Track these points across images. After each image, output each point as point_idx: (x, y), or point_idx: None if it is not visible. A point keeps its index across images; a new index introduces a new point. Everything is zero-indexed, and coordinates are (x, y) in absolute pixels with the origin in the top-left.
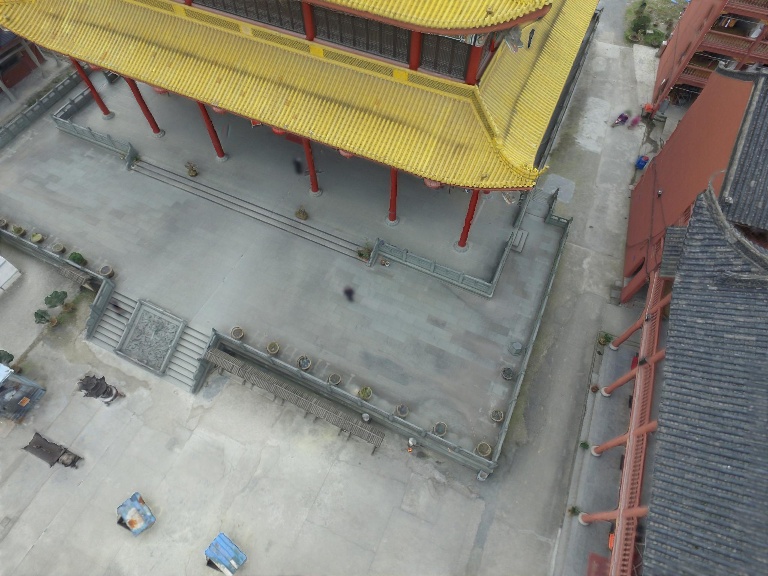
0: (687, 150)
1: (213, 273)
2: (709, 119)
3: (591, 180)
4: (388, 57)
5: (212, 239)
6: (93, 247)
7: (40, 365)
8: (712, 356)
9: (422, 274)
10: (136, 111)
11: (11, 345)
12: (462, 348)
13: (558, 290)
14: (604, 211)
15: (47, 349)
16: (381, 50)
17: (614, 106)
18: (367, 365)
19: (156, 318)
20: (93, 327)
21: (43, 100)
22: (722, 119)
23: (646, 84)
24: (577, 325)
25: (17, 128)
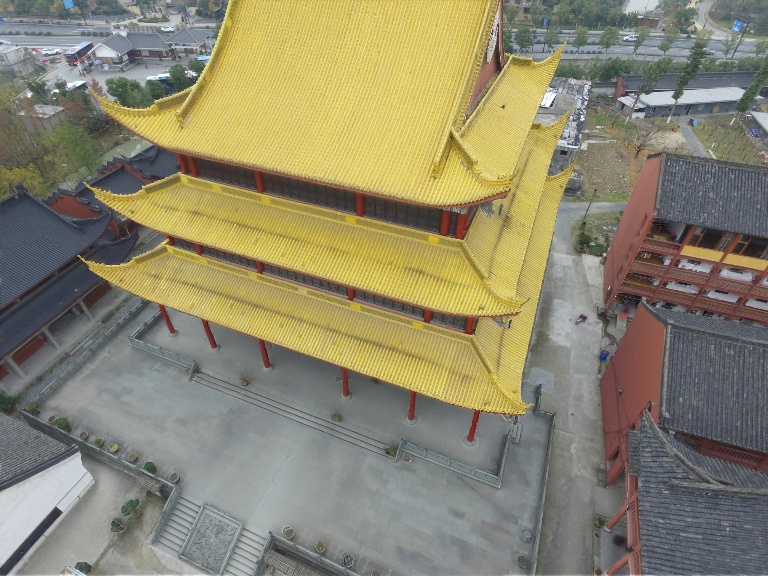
0: (633, 361)
1: (264, 475)
2: (643, 342)
3: (566, 372)
4: (408, 313)
5: (262, 442)
6: (161, 454)
7: (110, 573)
8: (674, 552)
9: (440, 468)
10: (196, 329)
11: (84, 554)
12: (481, 538)
13: (554, 475)
14: (581, 399)
15: (117, 556)
16: (403, 308)
17: (575, 306)
18: (402, 559)
19: (217, 521)
20: (159, 532)
21: (120, 322)
22: (651, 346)
23: (597, 287)
24: (574, 508)
25: (98, 347)
